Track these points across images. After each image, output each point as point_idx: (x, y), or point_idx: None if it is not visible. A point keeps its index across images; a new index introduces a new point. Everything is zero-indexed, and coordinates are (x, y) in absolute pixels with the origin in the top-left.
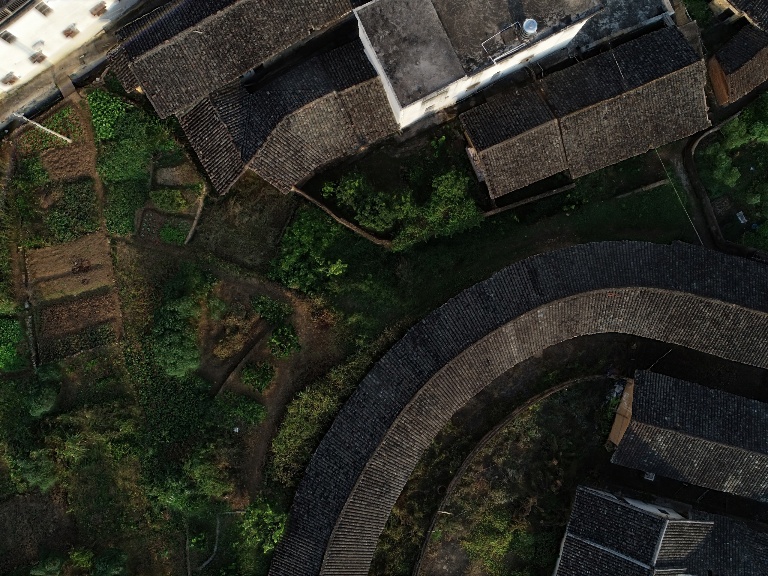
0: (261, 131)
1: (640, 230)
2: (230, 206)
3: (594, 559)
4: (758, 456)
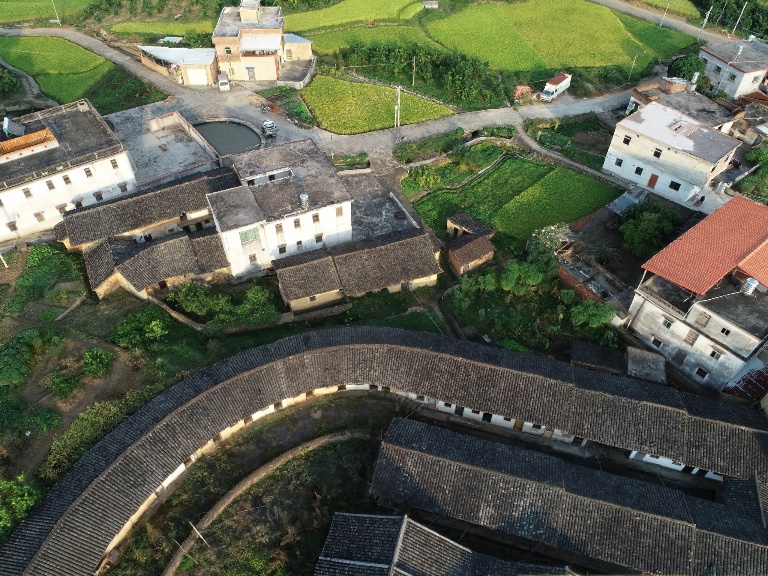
0: (133, 255)
1: None
2: (98, 305)
3: (340, 575)
4: (500, 477)
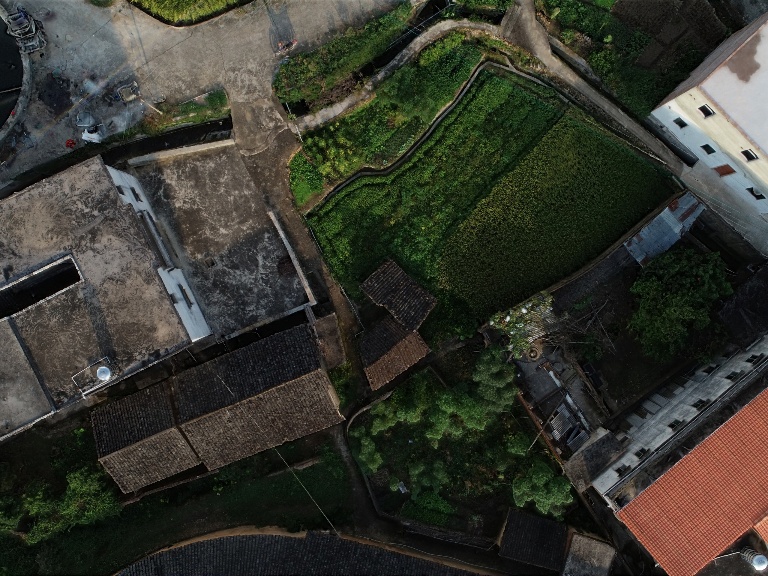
0: None
1: (294, 506)
2: None
3: None
4: None
